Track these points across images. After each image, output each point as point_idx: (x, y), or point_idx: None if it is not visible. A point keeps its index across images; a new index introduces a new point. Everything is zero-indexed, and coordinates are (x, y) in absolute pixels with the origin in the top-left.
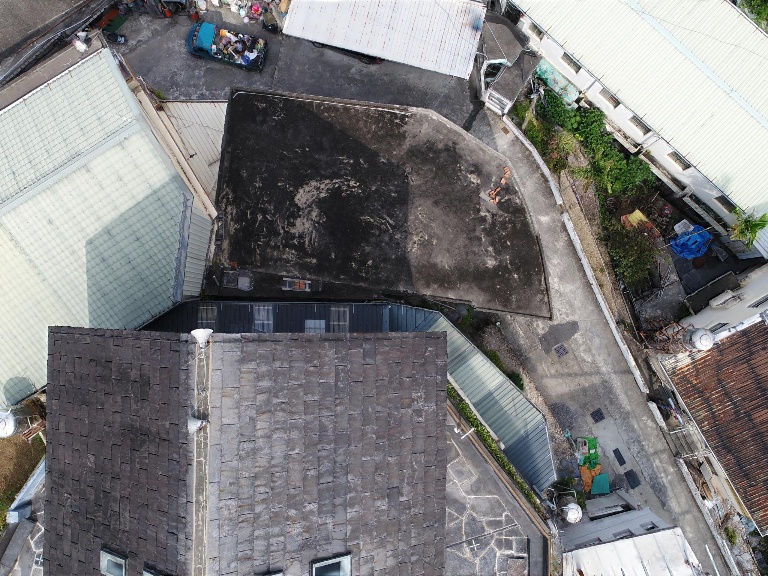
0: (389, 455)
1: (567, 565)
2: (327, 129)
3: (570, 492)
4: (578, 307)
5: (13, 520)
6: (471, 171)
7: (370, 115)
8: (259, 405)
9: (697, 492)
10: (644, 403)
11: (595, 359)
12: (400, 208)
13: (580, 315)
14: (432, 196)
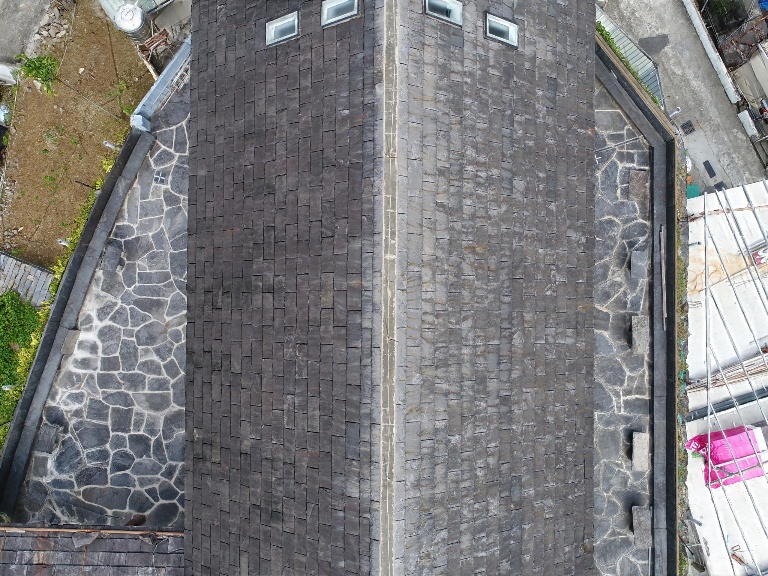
0: None
1: None
2: None
3: None
4: (668, 20)
5: (137, 123)
6: None
7: None
8: None
9: None
10: (734, 115)
11: (685, 72)
12: None
13: (670, 28)
14: None
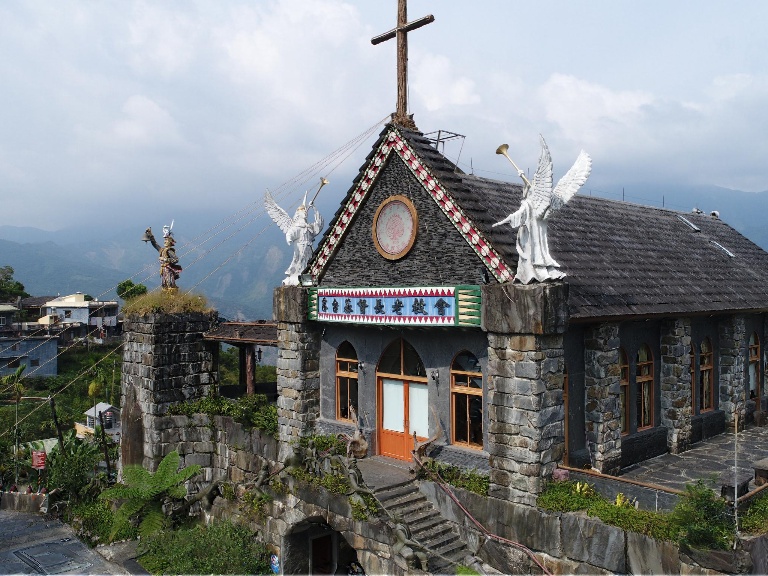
0: None
1: None
2: None
3: None
4: None
5: None
6: None
7: None
8: None
9: None
10: None
11: None
12: None
13: None
14: None
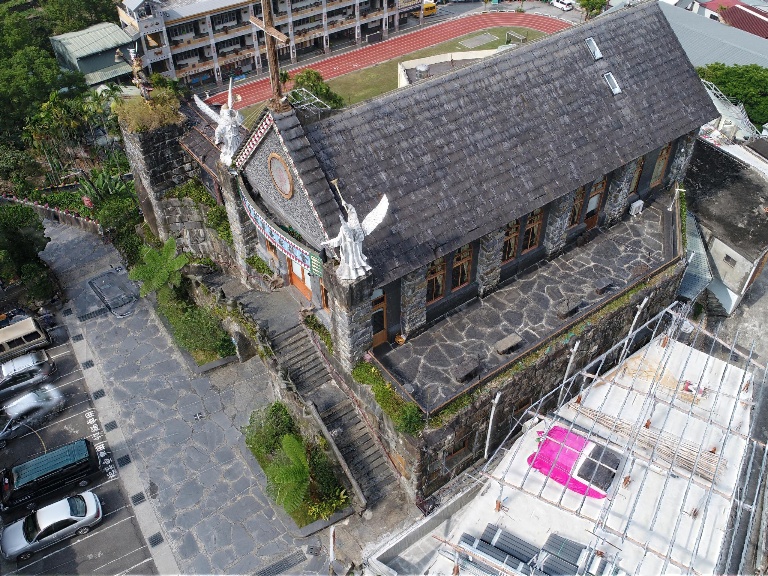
0: (663, 100)
1: None
2: (701, 151)
3: (689, 342)
4: (766, 351)
5: None
6: (763, 197)
7: (728, 159)
8: (647, 27)
9: None
10: None
11: None
12: (711, 186)
13: (764, 354)
14: (732, 192)
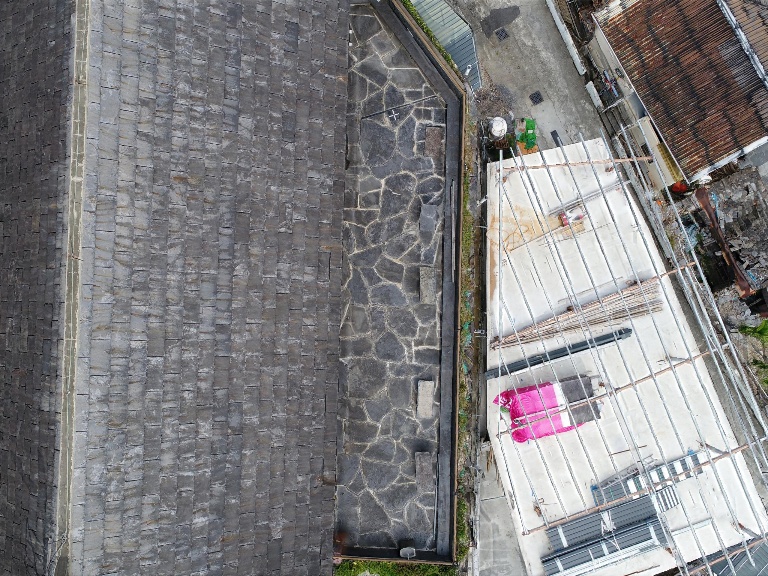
0: None
1: (491, 175)
2: None
3: None
4: None
5: None
6: None
7: None
8: None
9: (631, 169)
10: (582, 86)
11: (535, 43)
12: None
13: (521, 0)
14: None
